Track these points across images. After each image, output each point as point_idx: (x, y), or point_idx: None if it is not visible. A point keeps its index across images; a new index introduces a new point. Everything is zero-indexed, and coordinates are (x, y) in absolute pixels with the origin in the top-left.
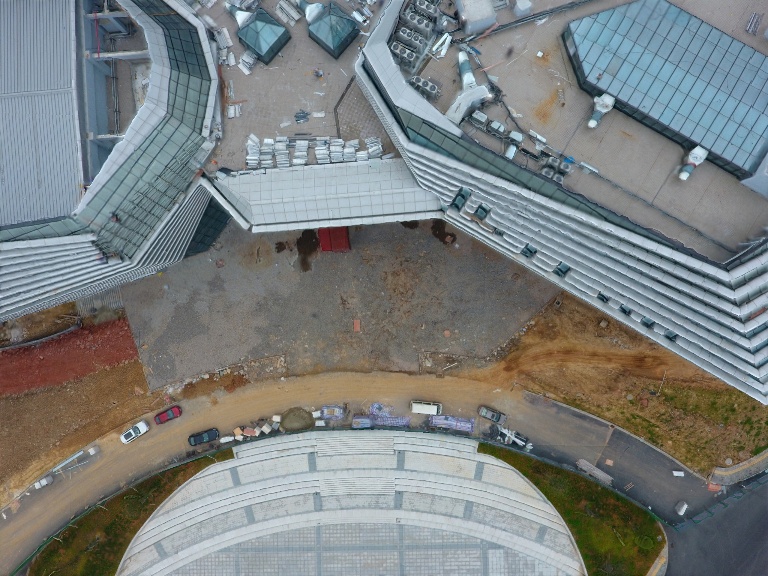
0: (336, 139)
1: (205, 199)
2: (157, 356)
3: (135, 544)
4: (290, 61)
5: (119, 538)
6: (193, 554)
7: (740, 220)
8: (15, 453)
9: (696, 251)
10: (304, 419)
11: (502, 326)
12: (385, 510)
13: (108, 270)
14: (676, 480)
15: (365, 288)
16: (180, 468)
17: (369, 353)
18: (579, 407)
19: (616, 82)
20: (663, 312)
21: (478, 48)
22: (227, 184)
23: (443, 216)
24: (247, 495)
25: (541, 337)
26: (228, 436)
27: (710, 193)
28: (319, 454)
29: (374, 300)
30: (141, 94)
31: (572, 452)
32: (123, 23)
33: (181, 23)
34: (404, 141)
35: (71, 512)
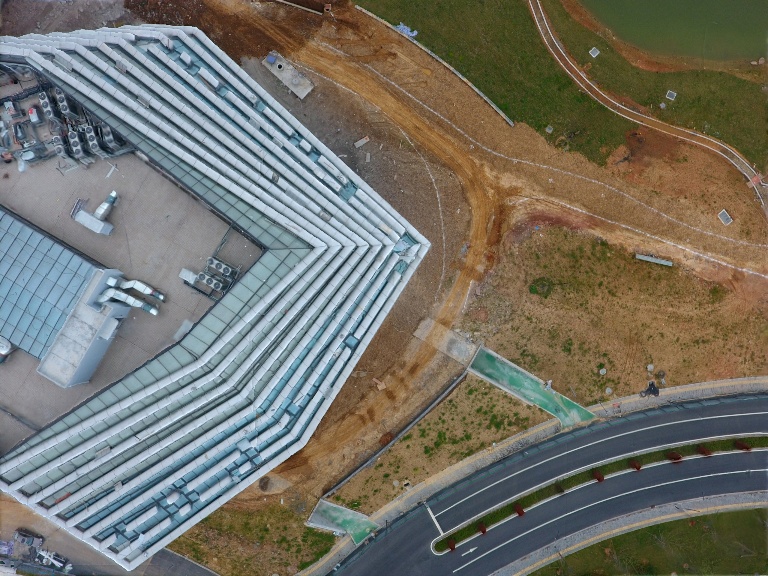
0: None
1: None
2: None
3: None
4: None
5: None
6: None
7: (61, 403)
8: None
9: (16, 434)
10: None
11: None
12: None
13: None
14: None
15: None
16: None
17: None
18: None
19: None
20: None
21: None
22: None
23: None
24: None
25: None
26: None
27: (32, 377)
28: None
29: None
30: None
31: (114, 571)
32: None
33: None
34: None
35: None
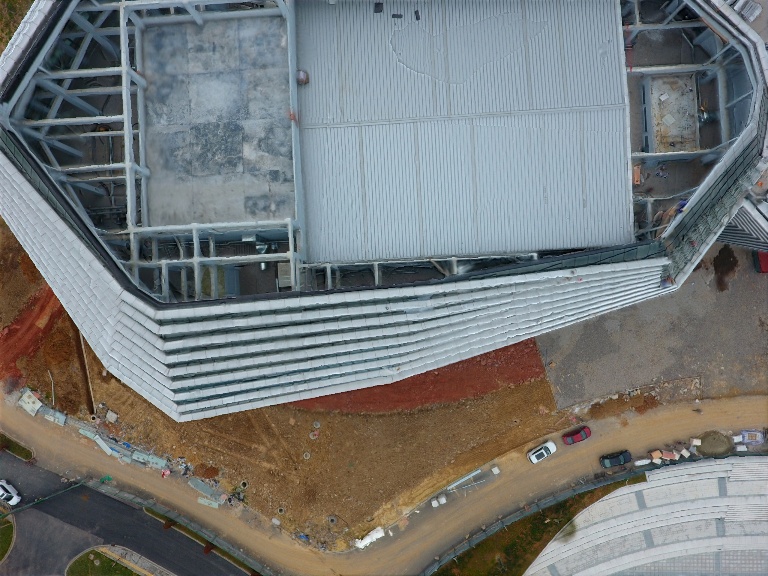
0: None
1: None
2: (565, 375)
3: (533, 566)
4: None
5: (519, 559)
6: None
7: None
8: (408, 470)
9: None
10: (725, 443)
11: None
12: None
13: (653, 294)
14: None
15: None
16: (588, 490)
17: None
18: None
19: None
20: None
21: None
22: None
23: None
24: (651, 519)
25: None
26: (646, 459)
27: None
28: (731, 479)
29: None
30: (657, 110)
31: None
32: (636, 35)
33: None
34: None
35: (465, 531)
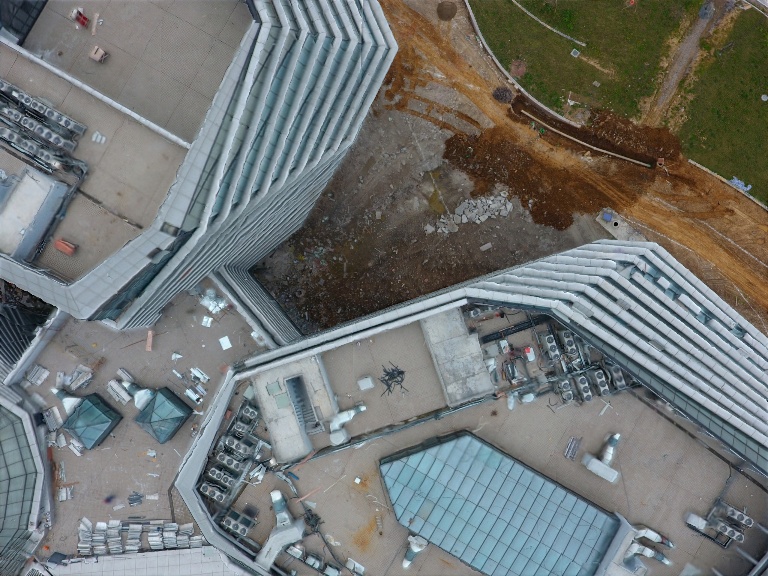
0: (170, 523)
1: None
2: None
3: None
4: (122, 441)
5: None
6: None
7: None
8: None
9: None
10: None
11: None
12: None
13: None
14: None
15: None
16: None
17: None
18: None
19: (427, 526)
20: None
21: (295, 473)
22: (58, 574)
23: None
24: None
25: None
26: None
27: None
28: None
29: None
30: None
31: None
32: None
33: (3, 417)
34: (224, 561)
35: None
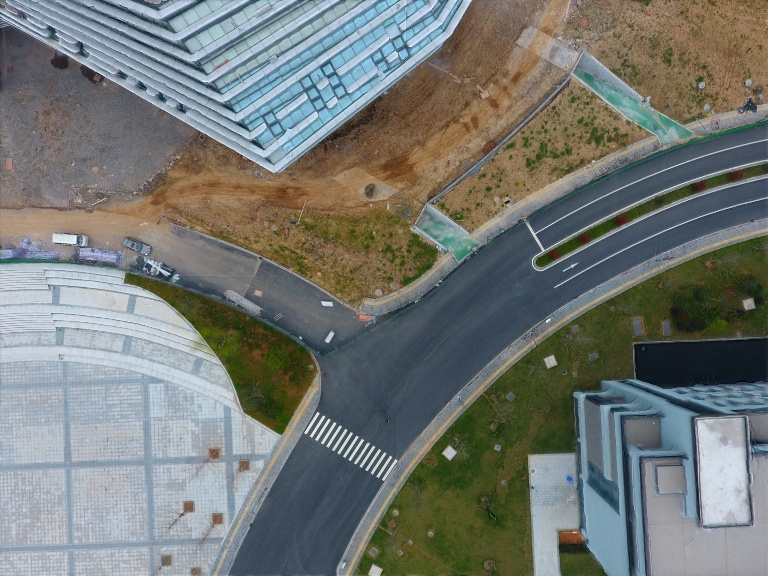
0: None
1: None
2: None
3: None
4: None
5: None
6: None
7: None
8: None
9: None
10: None
11: (148, 161)
12: (47, 347)
13: None
14: (326, 311)
15: (17, 127)
16: None
17: (21, 190)
18: (226, 239)
19: None
20: (157, 78)
21: None
22: None
23: None
24: None
25: (186, 171)
26: None
27: None
28: None
29: (26, 139)
30: None
31: (220, 283)
32: None
33: None
34: None
35: None
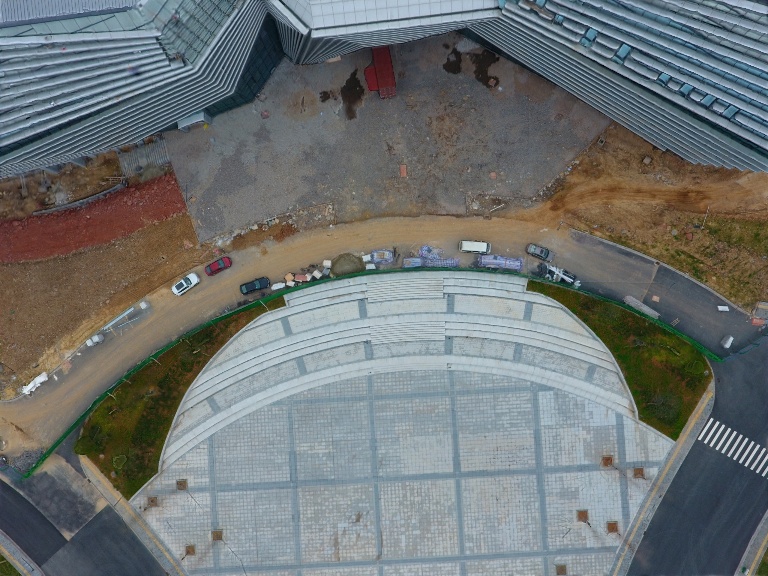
0: None
1: (259, 17)
2: (205, 208)
3: (189, 398)
4: None
5: (173, 391)
6: (246, 408)
7: None
8: (65, 313)
9: None
10: (354, 263)
11: (547, 166)
12: (436, 356)
13: (170, 75)
14: (721, 315)
15: (410, 134)
16: (232, 318)
17: (416, 198)
18: (625, 244)
19: None
20: (724, 83)
21: None
22: None
23: (500, 14)
24: (299, 345)
25: (586, 176)
26: (279, 282)
27: None
28: (369, 300)
29: (419, 145)
30: None
31: (619, 289)
32: None
33: None
34: None
35: (123, 369)
